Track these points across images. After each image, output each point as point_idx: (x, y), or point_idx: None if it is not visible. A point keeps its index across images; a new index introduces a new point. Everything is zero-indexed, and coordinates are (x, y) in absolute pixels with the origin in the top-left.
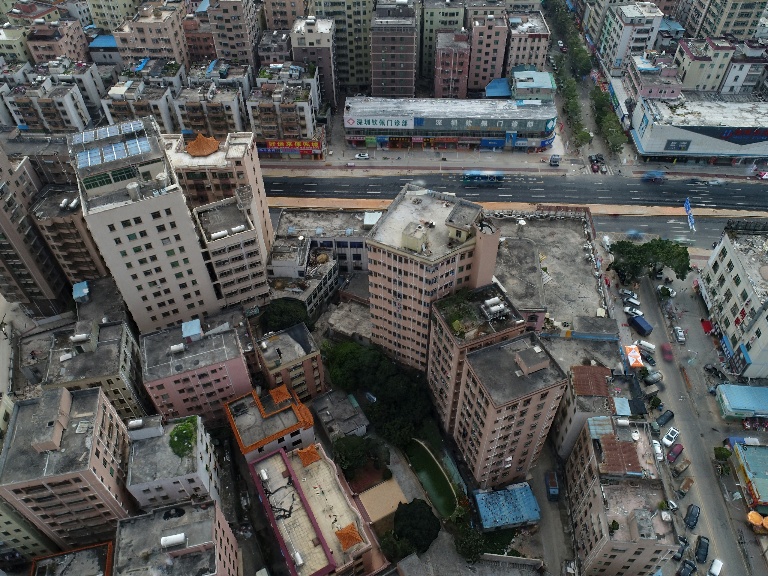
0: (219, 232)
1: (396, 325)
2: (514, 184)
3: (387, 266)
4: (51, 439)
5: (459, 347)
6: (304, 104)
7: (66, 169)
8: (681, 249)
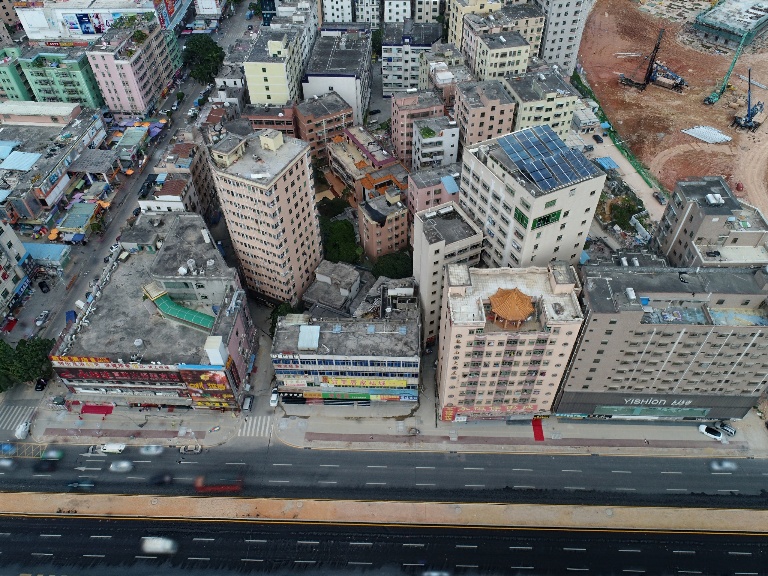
0: (446, 209)
1: None
2: (72, 569)
3: None
4: (479, 85)
5: None
6: None
7: None
8: None
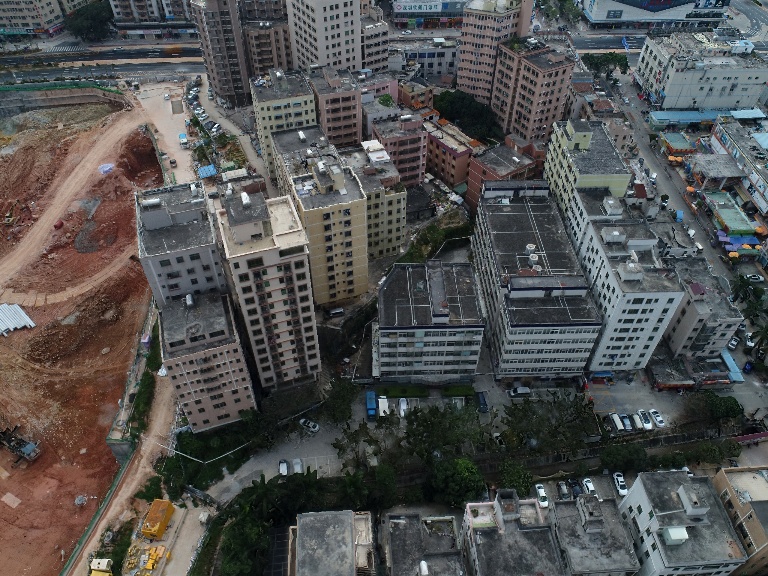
0: (369, 26)
1: (474, 71)
2: None
3: (474, 26)
4: None
5: (518, 57)
6: None
7: (257, 7)
8: (623, 56)
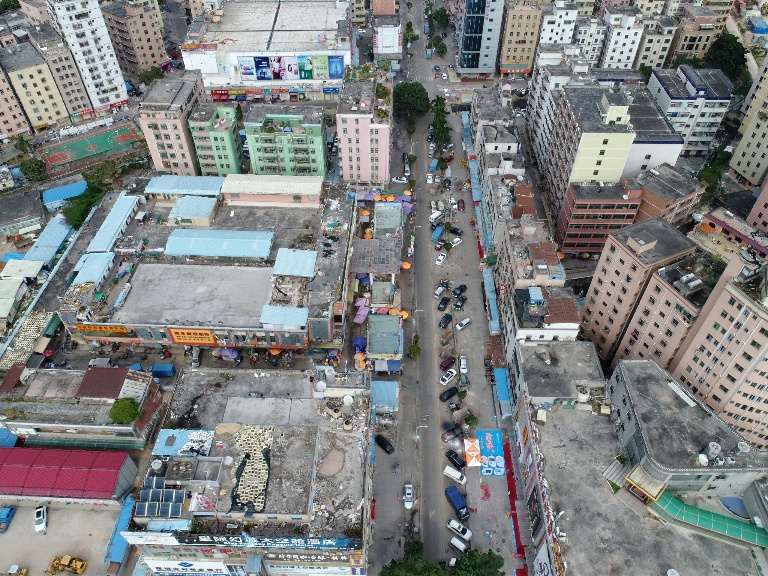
0: None
1: None
2: None
3: None
4: None
5: None
6: None
7: None
8: None
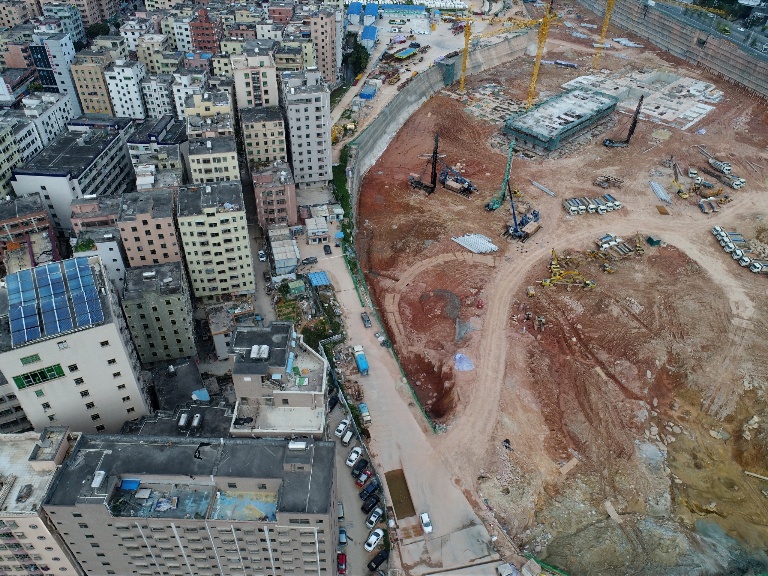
0: None
1: None
2: None
3: None
4: (140, 195)
5: None
6: None
7: None
8: None
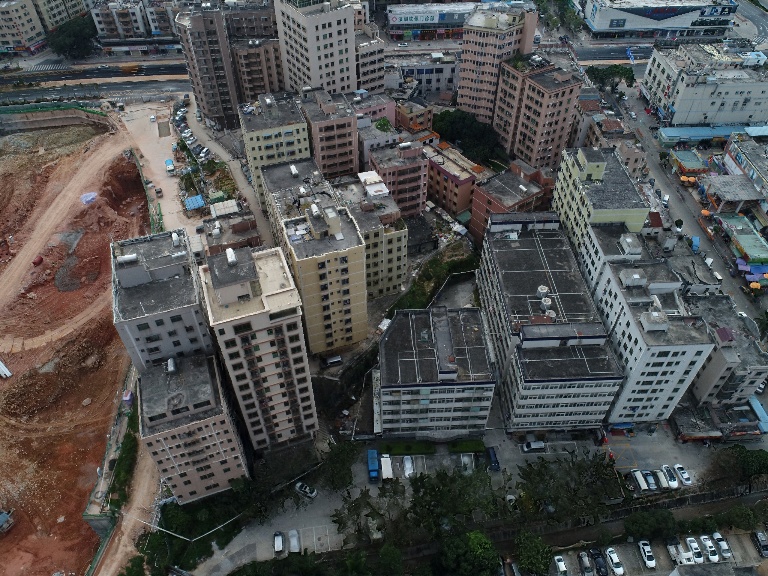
0: (364, 43)
1: (475, 90)
2: None
3: (475, 43)
4: None
5: (522, 76)
6: (366, 3)
7: (246, 24)
8: (628, 68)
